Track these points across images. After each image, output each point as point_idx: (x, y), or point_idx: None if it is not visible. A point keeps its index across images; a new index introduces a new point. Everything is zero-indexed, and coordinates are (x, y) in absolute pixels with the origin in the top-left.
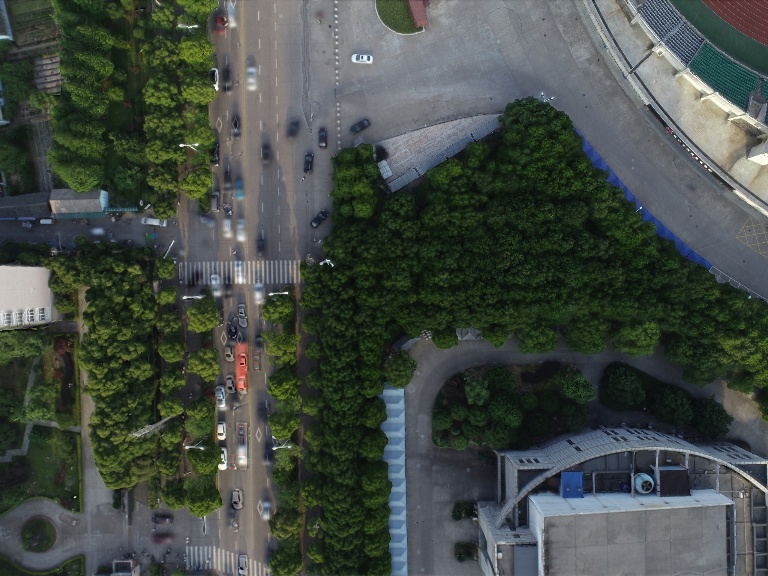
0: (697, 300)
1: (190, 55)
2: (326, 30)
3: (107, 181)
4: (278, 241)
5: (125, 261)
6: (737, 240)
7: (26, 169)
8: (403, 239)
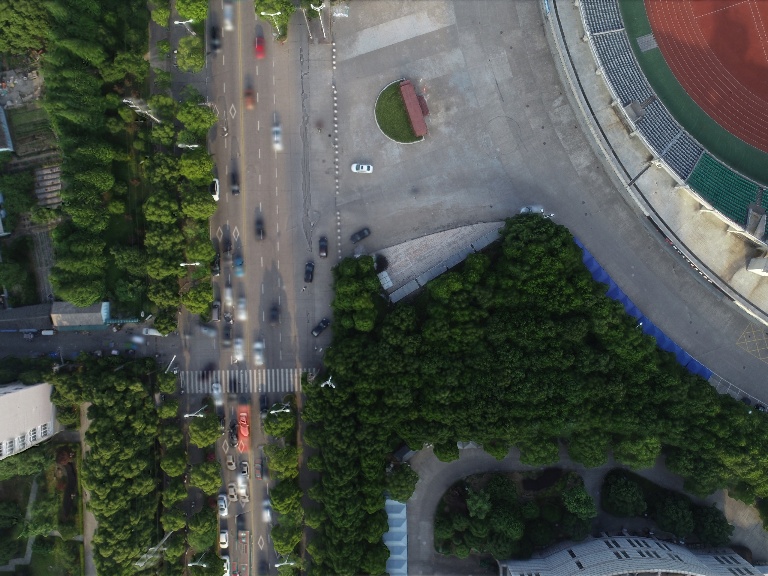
0: (698, 415)
1: (190, 173)
2: (326, 139)
3: (108, 293)
4: (279, 350)
5: (127, 378)
6: (737, 346)
7: (27, 281)
8: (404, 355)
